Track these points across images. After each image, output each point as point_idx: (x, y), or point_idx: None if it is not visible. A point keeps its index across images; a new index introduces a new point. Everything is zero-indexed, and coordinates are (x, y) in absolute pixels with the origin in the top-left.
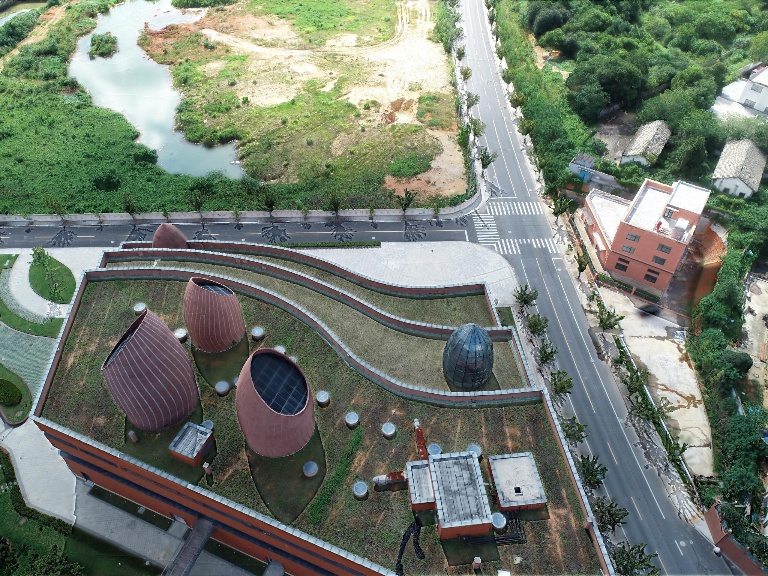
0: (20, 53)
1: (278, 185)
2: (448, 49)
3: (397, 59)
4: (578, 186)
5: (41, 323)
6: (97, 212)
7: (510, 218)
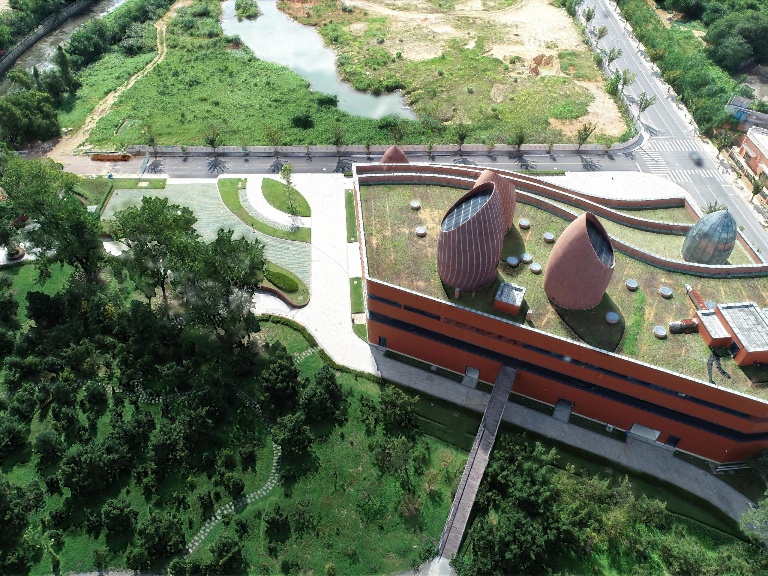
0: (179, 14)
1: (454, 125)
2: (573, 12)
3: (526, 21)
4: (734, 126)
5: (290, 231)
6: (303, 145)
7: (674, 153)
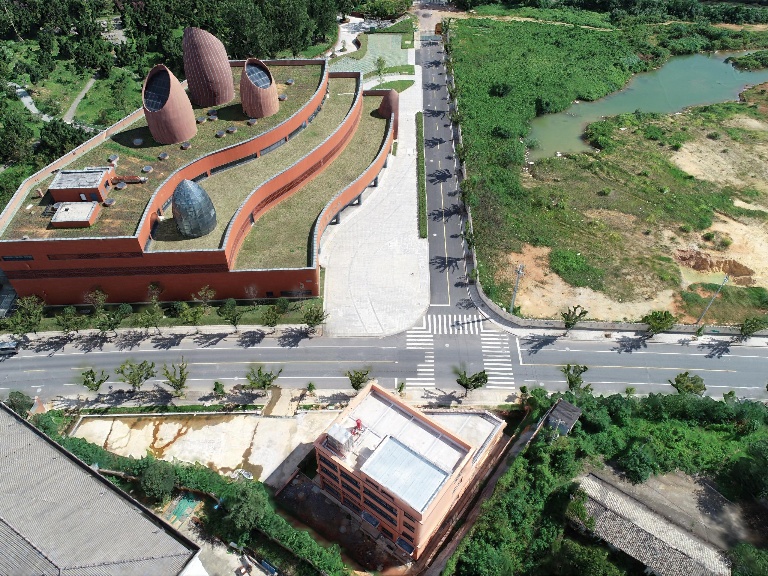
0: (692, 24)
1: None
2: None
3: None
4: None
5: None
6: None
7: (475, 350)
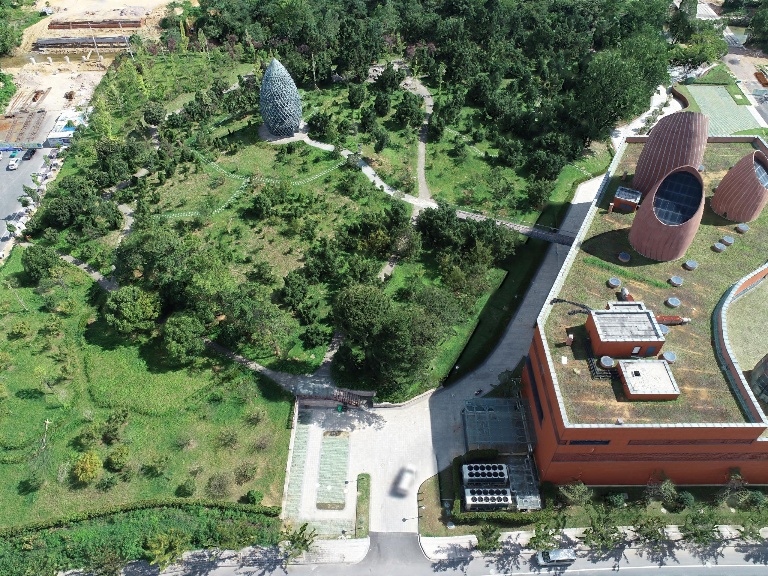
0: None
1: None
2: None
3: None
4: None
5: None
6: None
7: None
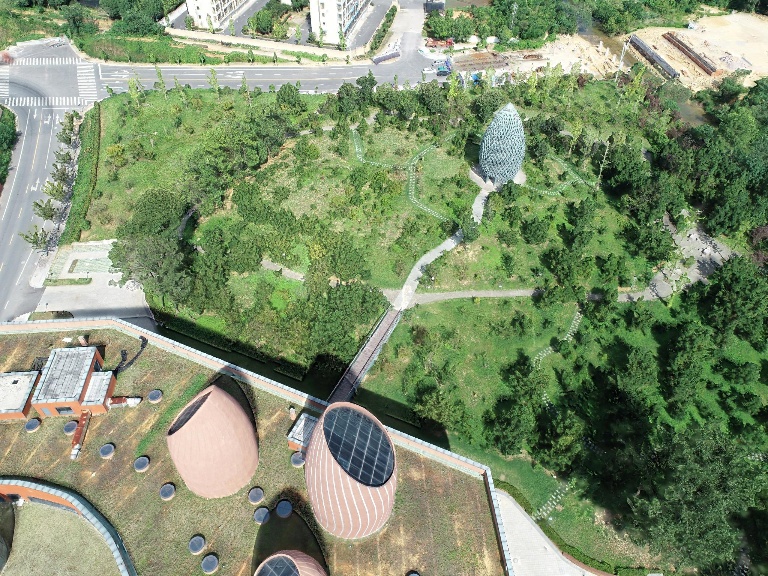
0: None
1: None
2: None
3: None
4: None
5: None
6: None
7: None
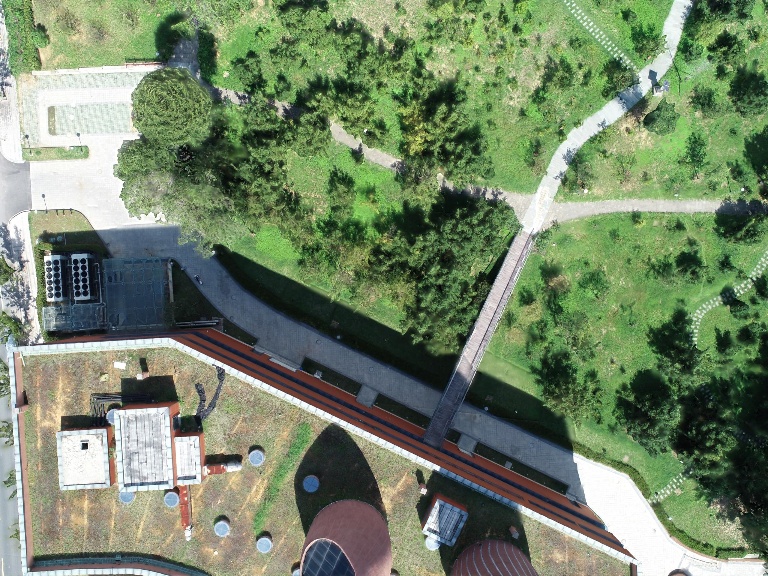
0: None
1: None
2: None
3: None
4: None
5: None
6: None
7: None
